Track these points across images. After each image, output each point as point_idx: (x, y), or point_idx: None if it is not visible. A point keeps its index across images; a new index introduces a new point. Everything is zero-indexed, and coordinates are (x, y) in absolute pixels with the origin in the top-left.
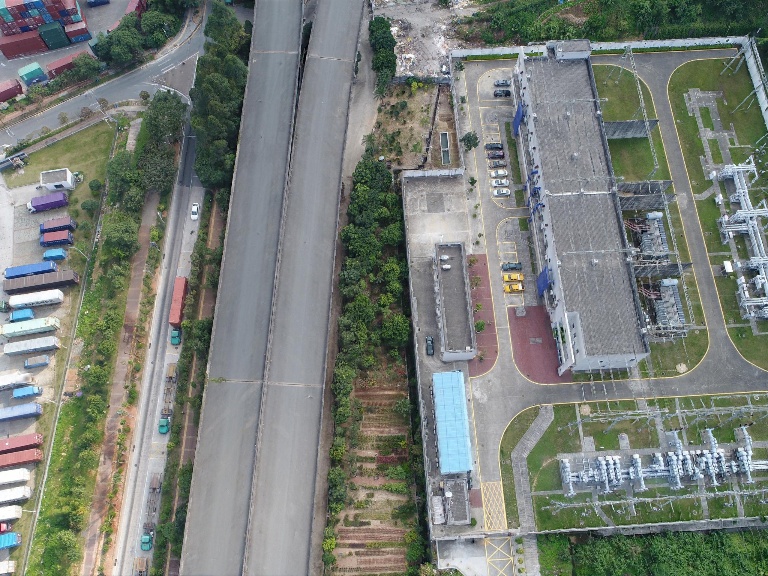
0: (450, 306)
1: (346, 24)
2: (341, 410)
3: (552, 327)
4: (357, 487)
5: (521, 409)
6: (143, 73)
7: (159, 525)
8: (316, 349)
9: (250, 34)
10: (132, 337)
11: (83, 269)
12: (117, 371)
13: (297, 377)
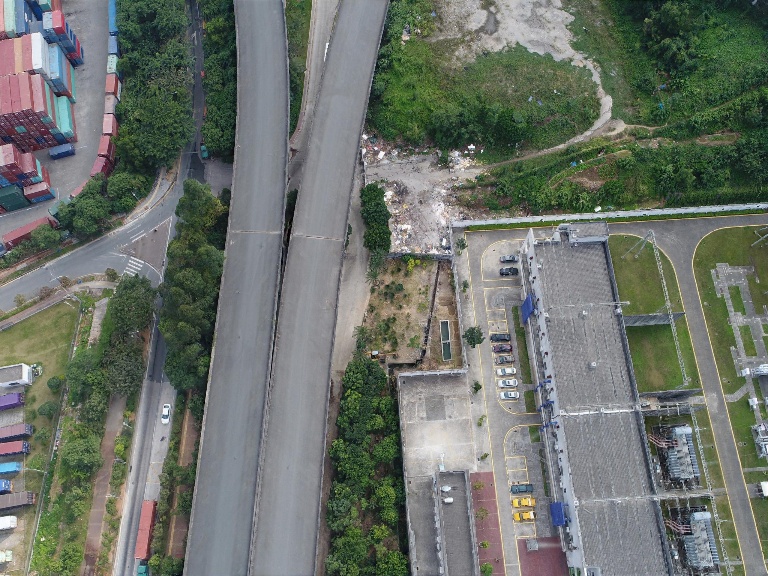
0: (453, 550)
1: (335, 195)
2: None
3: (568, 565)
4: None
5: None
6: (110, 241)
7: None
8: None
9: (228, 207)
10: (94, 571)
11: (40, 484)
12: None
13: None
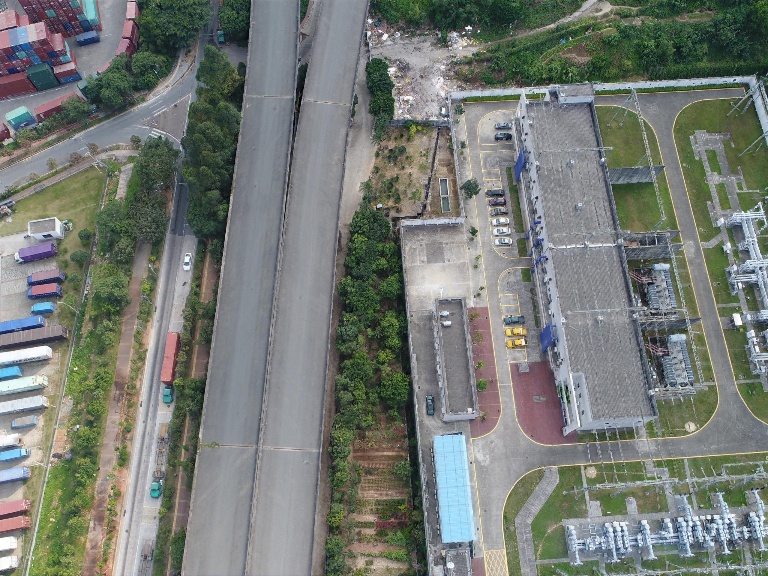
0: (451, 365)
1: (342, 66)
2: (339, 475)
3: (556, 384)
4: (356, 554)
5: (525, 472)
6: (134, 115)
7: None
8: (312, 411)
9: (244, 77)
10: (123, 395)
11: (72, 323)
12: (107, 431)
13: (293, 441)
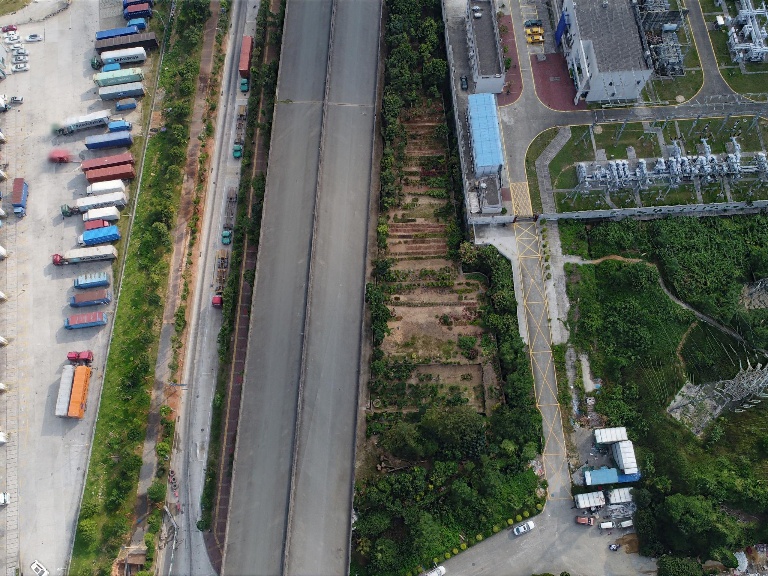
0: (482, 45)
1: None
2: (390, 126)
3: (569, 68)
4: (404, 193)
5: (543, 129)
6: None
7: (237, 225)
8: (368, 79)
9: None
10: (207, 86)
11: (162, 36)
12: (195, 112)
13: (353, 99)
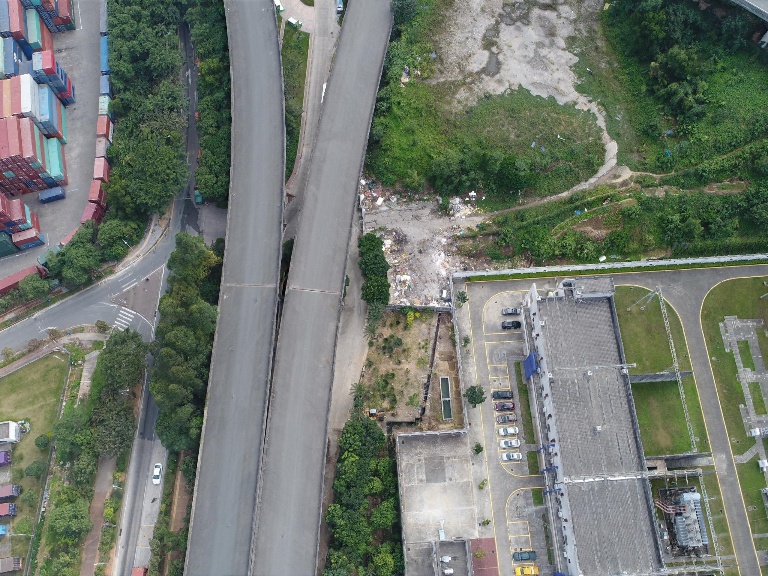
0: None
1: (332, 246)
2: None
3: None
4: None
5: None
6: (101, 290)
7: None
8: None
9: (221, 258)
10: None
11: (27, 548)
12: None
13: None
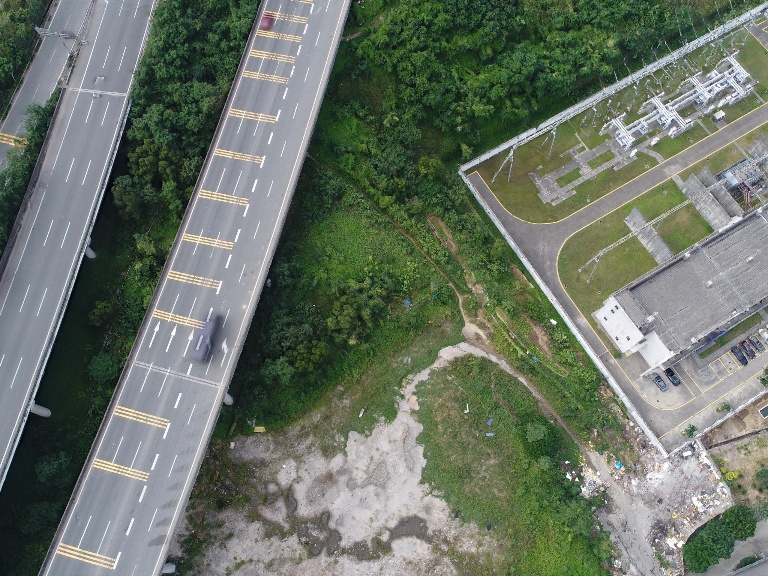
0: None
1: None
2: None
3: None
4: None
5: None
6: None
7: None
8: None
9: None
10: None
11: None
12: None
13: None
